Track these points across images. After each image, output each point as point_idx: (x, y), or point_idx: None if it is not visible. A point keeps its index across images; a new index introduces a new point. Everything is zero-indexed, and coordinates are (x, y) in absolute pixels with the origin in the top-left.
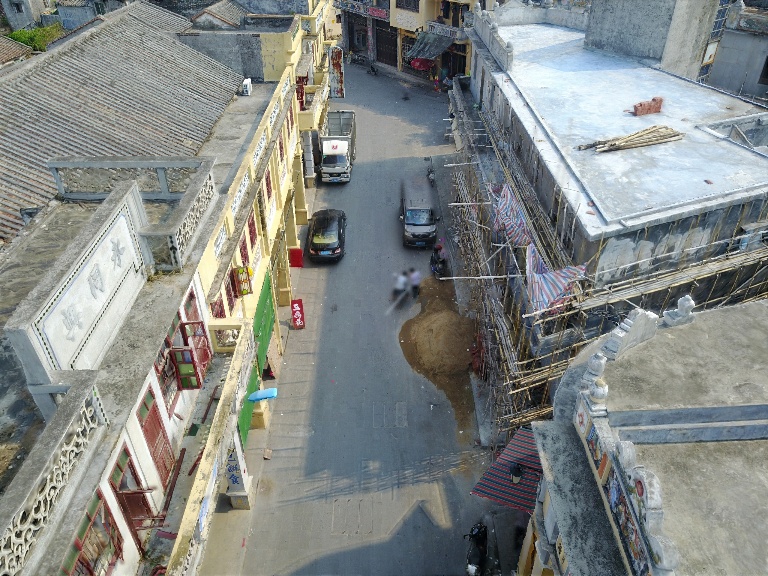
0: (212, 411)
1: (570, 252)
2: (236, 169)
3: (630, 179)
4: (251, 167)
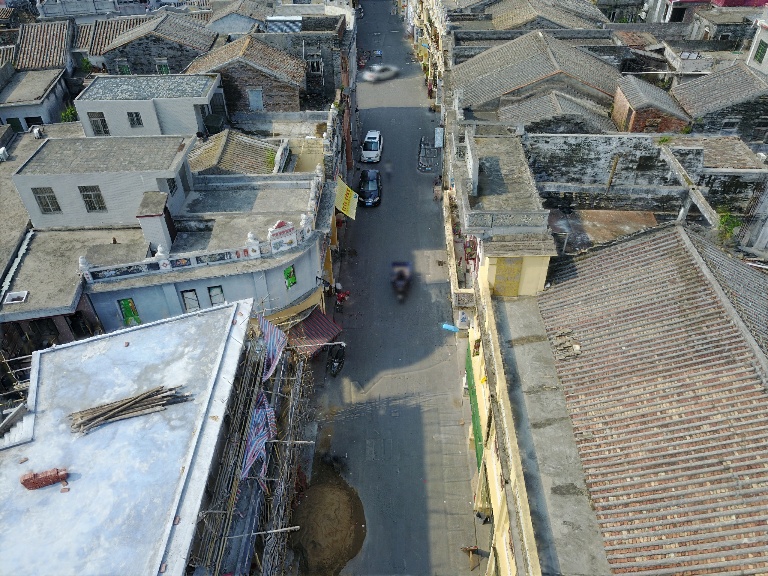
0: (463, 278)
1: (241, 367)
2: (522, 415)
3: (183, 350)
4: None
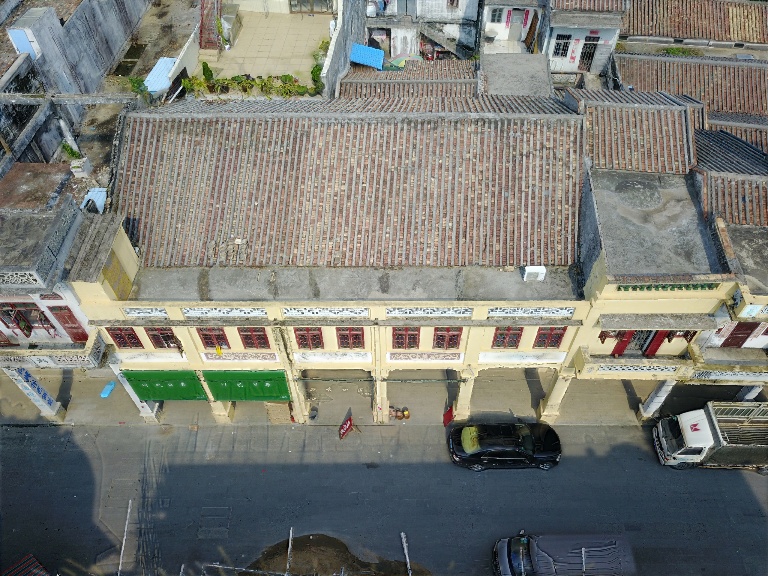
0: None
1: None
2: None
3: None
4: (269, 311)
